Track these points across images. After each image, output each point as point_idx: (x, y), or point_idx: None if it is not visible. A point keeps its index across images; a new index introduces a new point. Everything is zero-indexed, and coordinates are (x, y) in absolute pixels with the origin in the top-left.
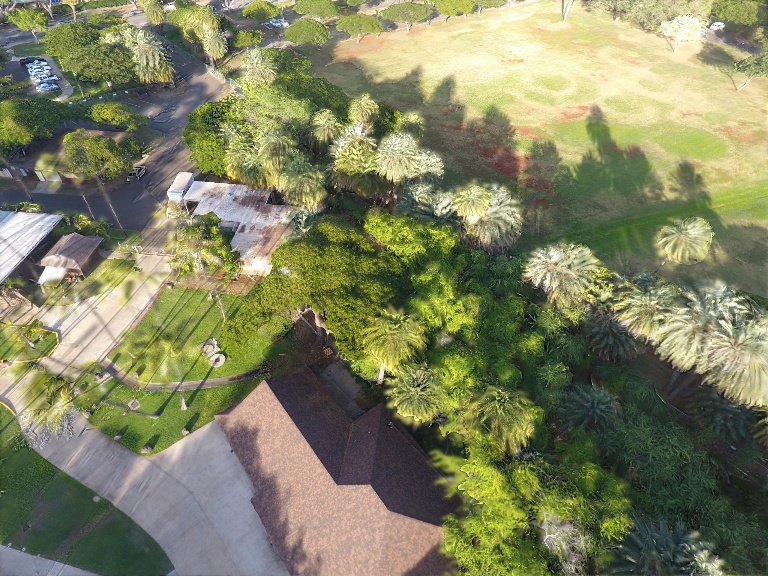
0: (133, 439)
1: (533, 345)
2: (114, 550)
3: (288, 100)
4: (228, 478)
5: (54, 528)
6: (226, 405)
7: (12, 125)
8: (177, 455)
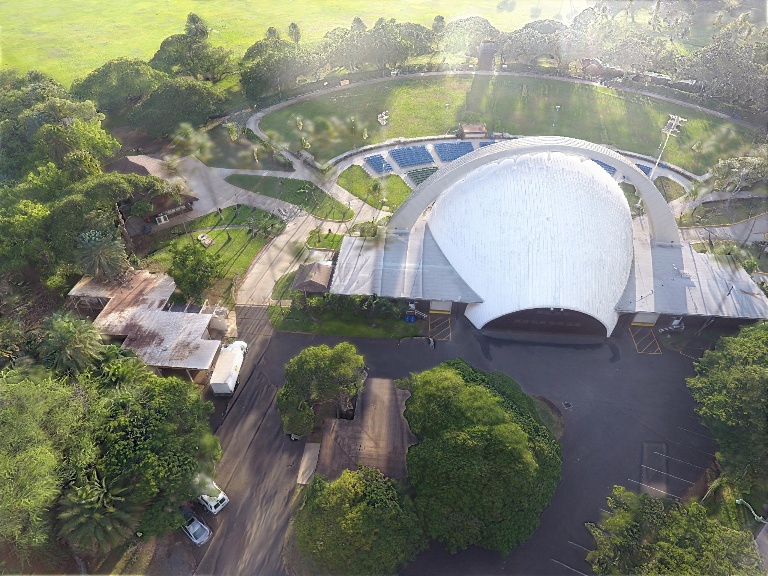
0: (247, 208)
1: (6, 186)
2: (246, 180)
3: (1, 386)
4: (201, 198)
5: (271, 183)
6: (199, 220)
7: (446, 374)
8: (225, 204)
